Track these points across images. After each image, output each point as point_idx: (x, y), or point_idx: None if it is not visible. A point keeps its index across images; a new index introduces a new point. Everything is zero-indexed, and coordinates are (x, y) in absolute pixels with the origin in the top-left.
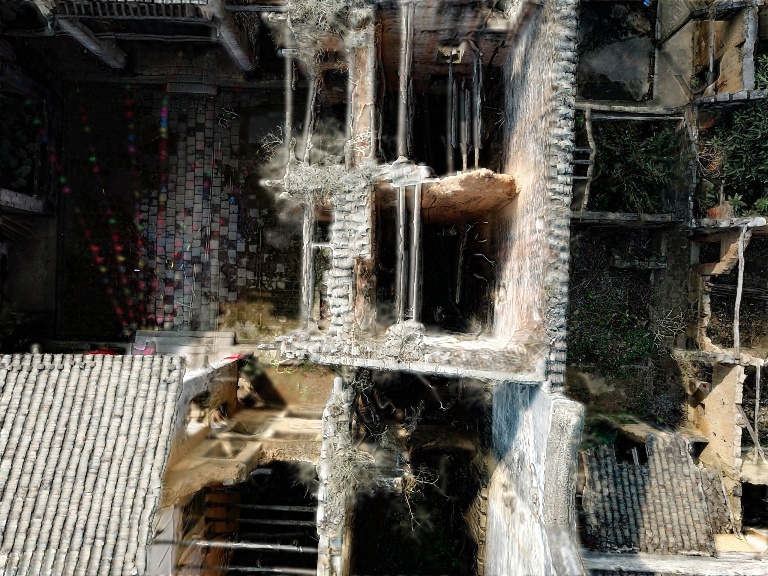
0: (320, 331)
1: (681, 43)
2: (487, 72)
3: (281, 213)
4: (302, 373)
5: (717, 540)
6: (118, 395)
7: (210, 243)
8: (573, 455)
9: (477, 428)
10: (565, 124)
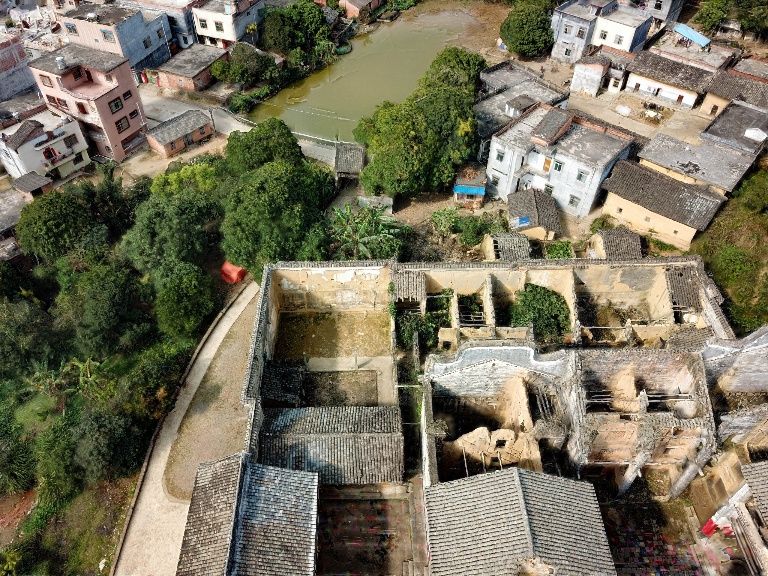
0: None
1: None
2: None
3: (617, 524)
4: (697, 505)
5: None
6: (765, 483)
7: (646, 562)
8: (723, 339)
9: None
10: (623, 351)
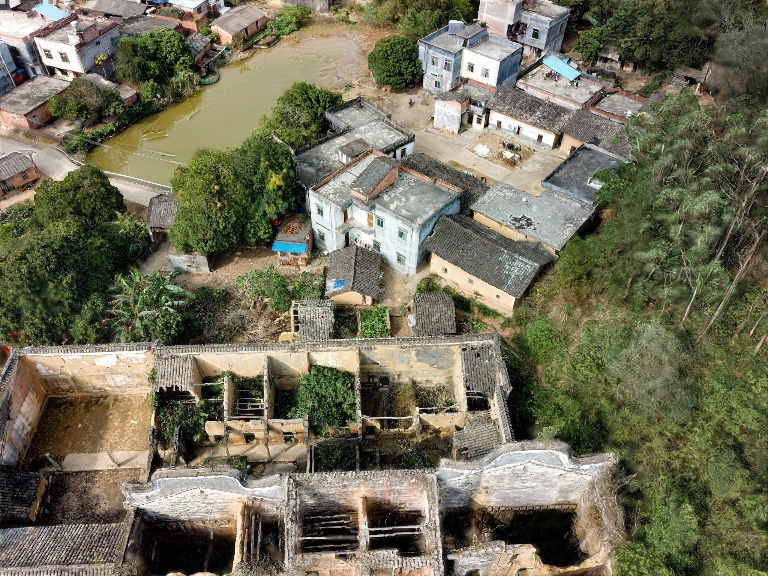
0: (430, 575)
1: (270, 450)
2: (306, 523)
3: None
4: None
5: (493, 418)
6: None
7: None
8: None
9: (464, 517)
10: (348, 474)
